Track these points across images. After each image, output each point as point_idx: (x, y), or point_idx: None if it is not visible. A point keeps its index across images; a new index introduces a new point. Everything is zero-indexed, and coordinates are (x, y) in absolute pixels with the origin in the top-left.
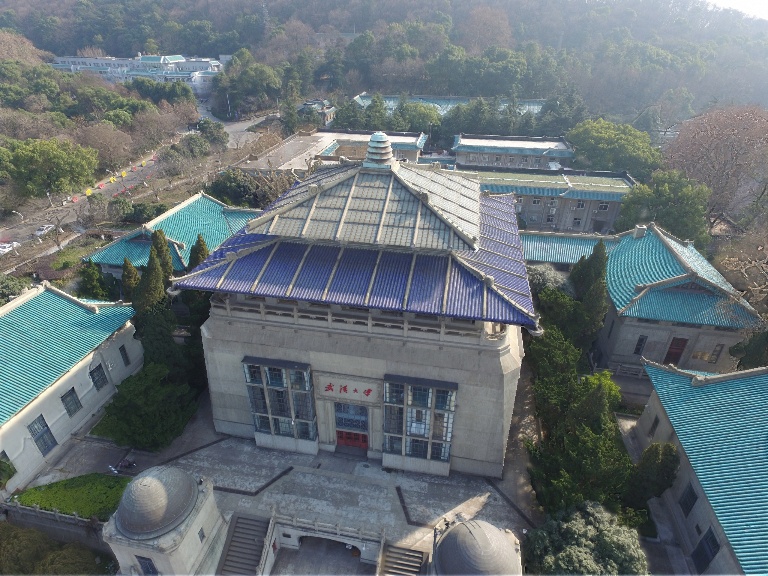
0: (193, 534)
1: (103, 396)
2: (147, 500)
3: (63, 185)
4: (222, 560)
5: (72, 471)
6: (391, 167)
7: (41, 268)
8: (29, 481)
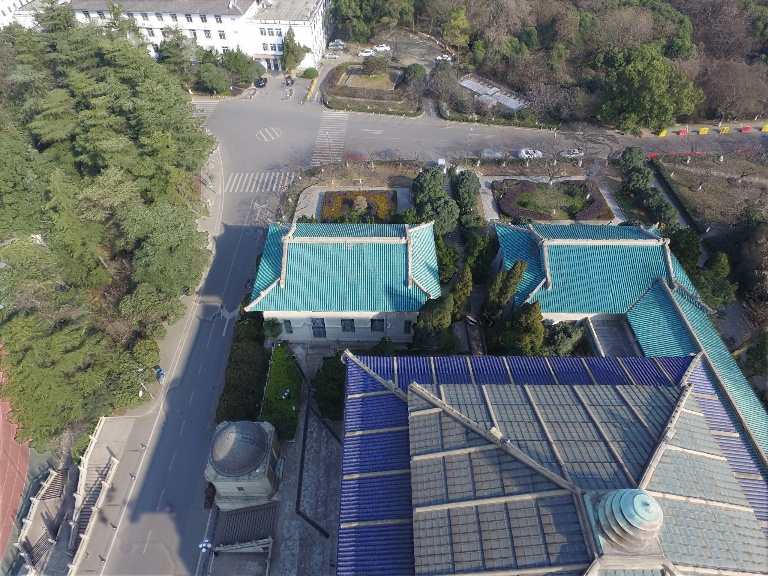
0: (230, 484)
1: (374, 336)
2: (219, 444)
3: (629, 120)
4: (252, 508)
5: (307, 361)
6: (604, 555)
7: (511, 193)
8: (296, 342)
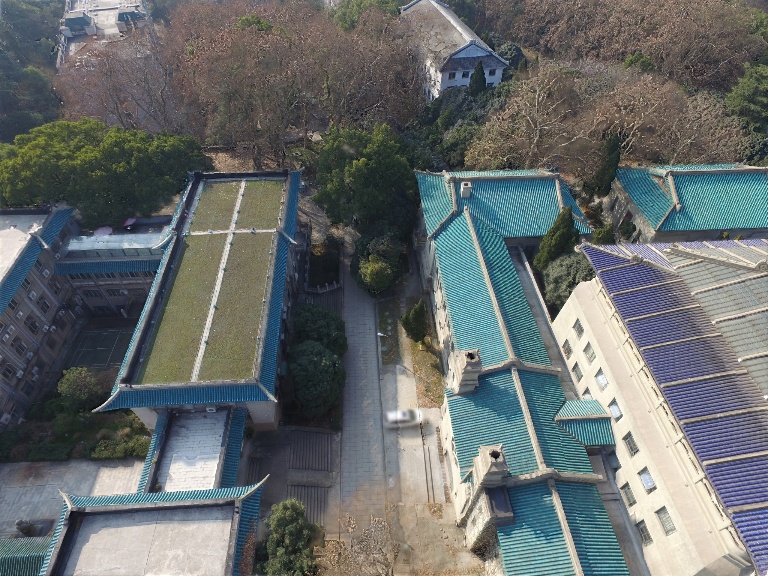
0: None
1: None
2: None
3: None
4: None
5: None
6: None
7: None
8: None
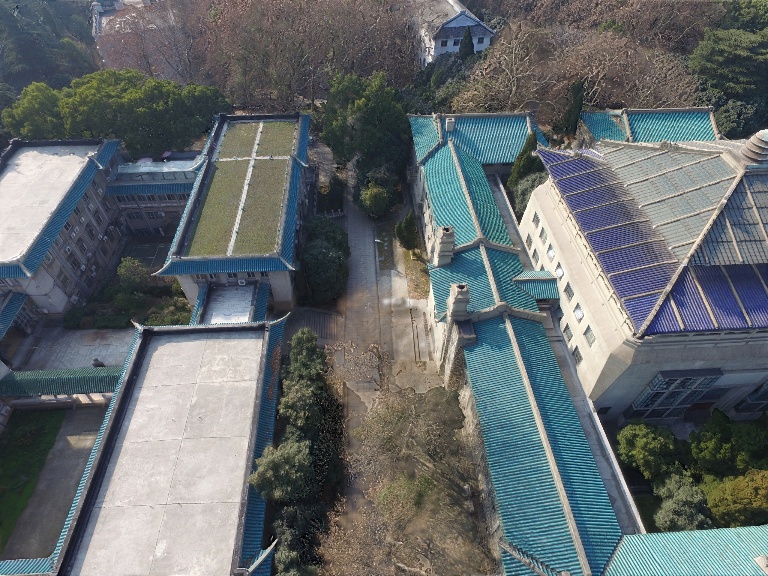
0: None
1: None
2: None
3: None
4: None
5: None
6: None
7: None
8: None
